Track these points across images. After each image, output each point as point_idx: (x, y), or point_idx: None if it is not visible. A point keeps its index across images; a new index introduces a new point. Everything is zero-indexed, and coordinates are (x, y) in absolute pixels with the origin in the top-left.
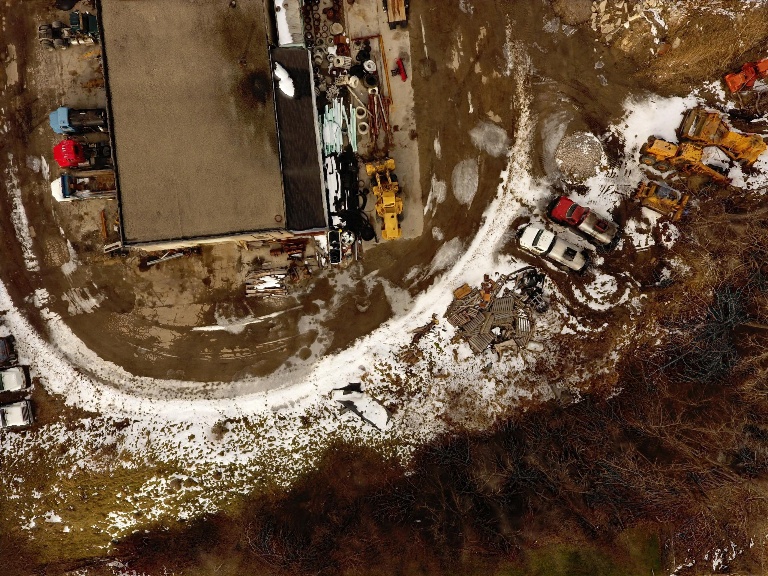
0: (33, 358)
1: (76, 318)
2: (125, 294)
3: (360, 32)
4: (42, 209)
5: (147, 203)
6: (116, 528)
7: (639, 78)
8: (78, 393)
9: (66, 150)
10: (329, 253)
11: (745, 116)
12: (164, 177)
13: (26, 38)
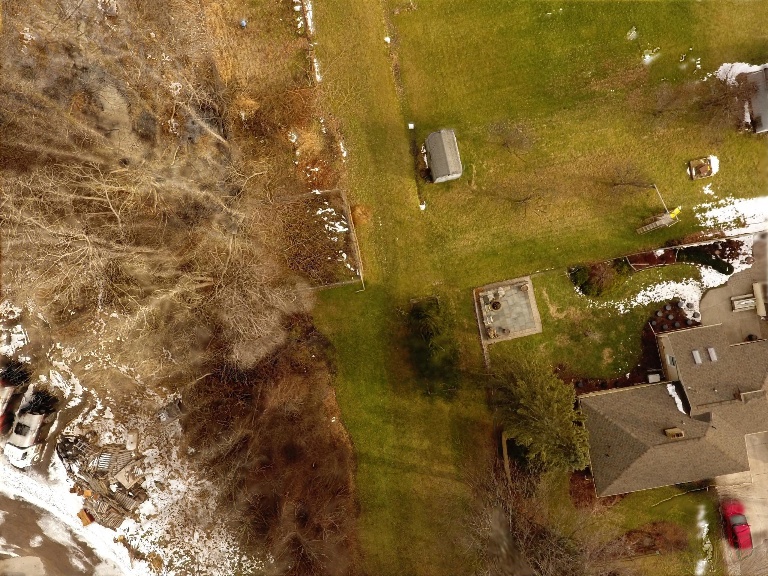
0: None
1: None
2: None
3: None
4: None
5: None
6: None
7: None
8: None
9: None
10: None
11: None
12: None
13: None
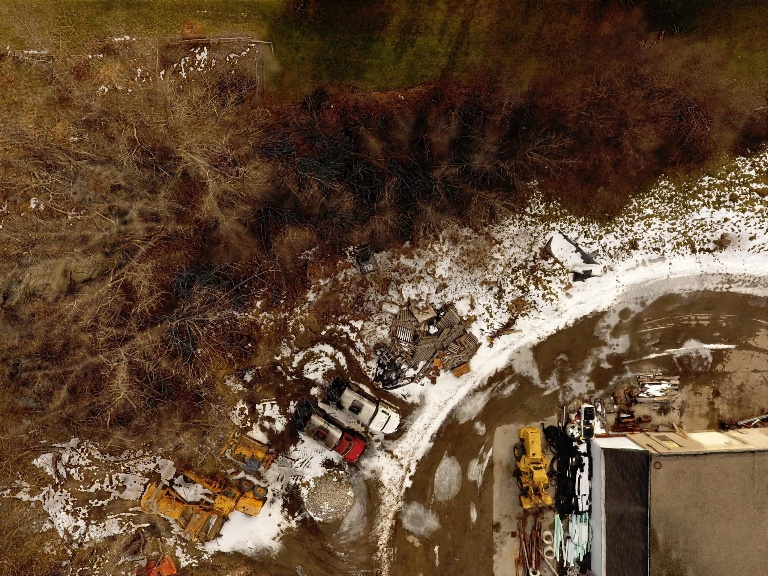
0: None
1: None
2: None
3: None
4: None
5: None
6: None
7: (264, 572)
8: None
9: None
10: None
11: (157, 531)
12: (765, 512)
13: None
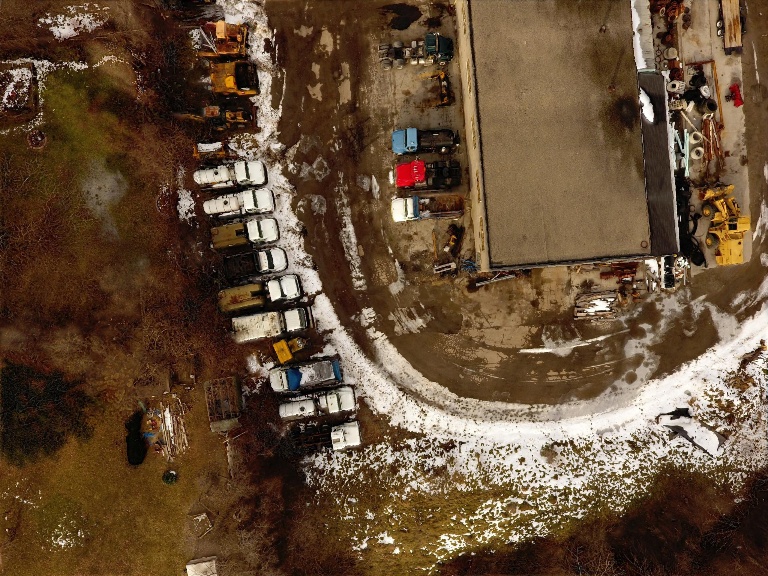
0: (359, 377)
1: (402, 338)
2: (452, 315)
3: (693, 57)
4: (371, 228)
5: (513, 226)
6: (445, 550)
7: None
8: (403, 413)
9: (418, 171)
10: (664, 278)
11: None
12: (531, 201)
13: (360, 57)
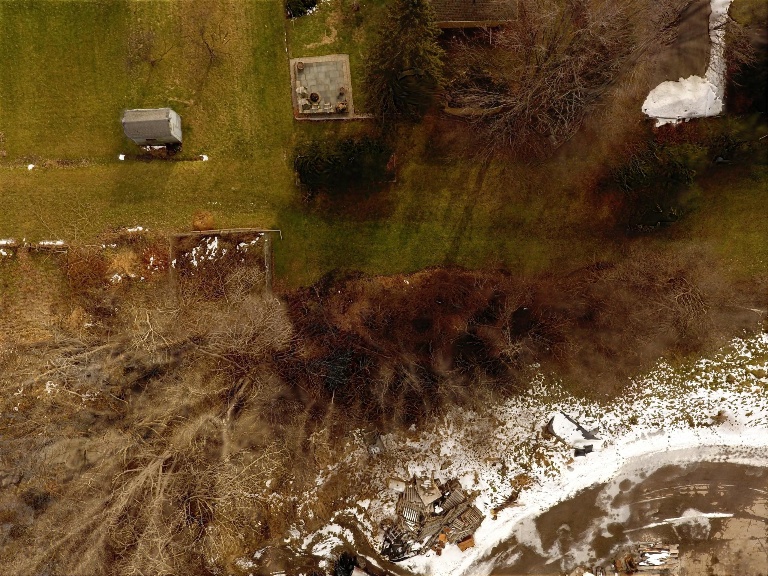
0: None
1: None
2: None
3: None
4: None
5: None
6: None
7: None
8: None
9: None
10: None
11: None
12: None
13: None
